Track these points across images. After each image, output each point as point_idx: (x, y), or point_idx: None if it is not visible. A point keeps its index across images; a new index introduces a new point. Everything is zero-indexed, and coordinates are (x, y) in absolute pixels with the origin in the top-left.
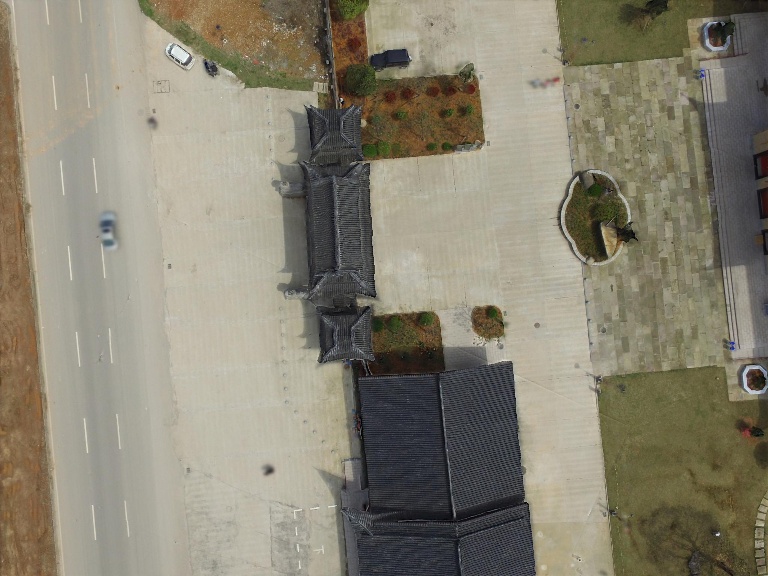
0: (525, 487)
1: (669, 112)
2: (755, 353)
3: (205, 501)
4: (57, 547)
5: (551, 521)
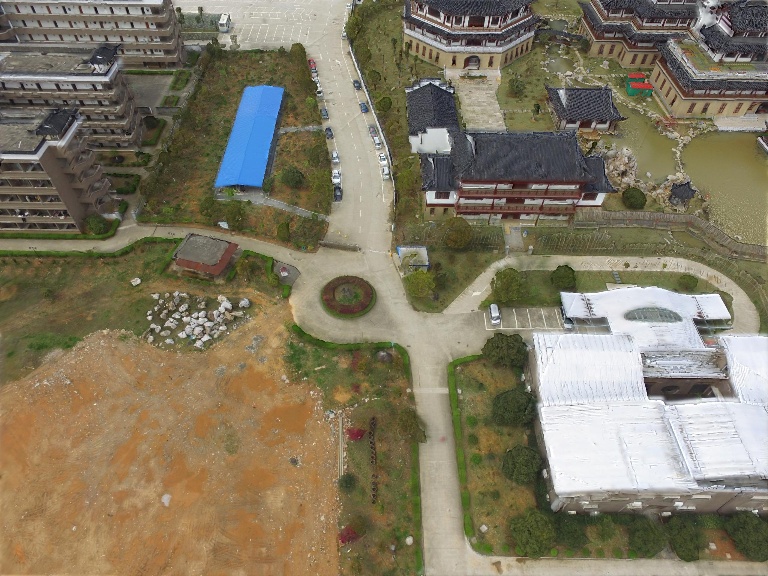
0: None
1: None
2: None
3: None
4: None
5: None
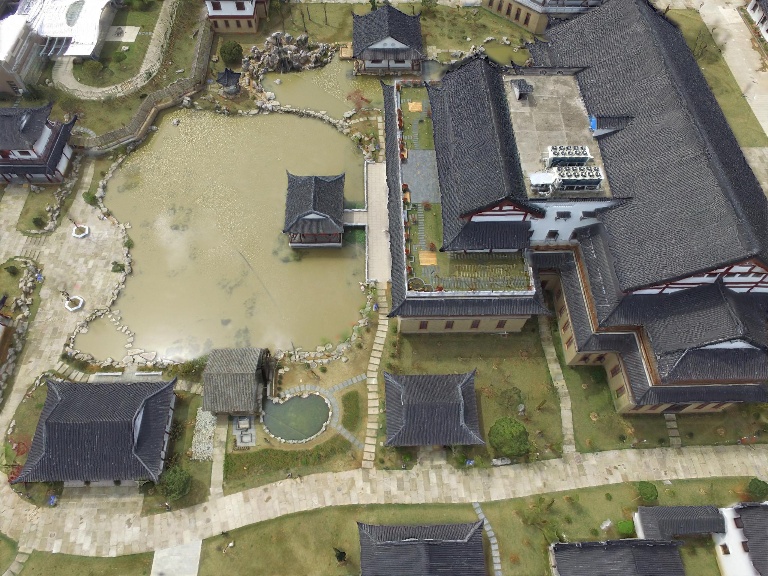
0: None
1: None
2: None
3: None
4: None
5: None
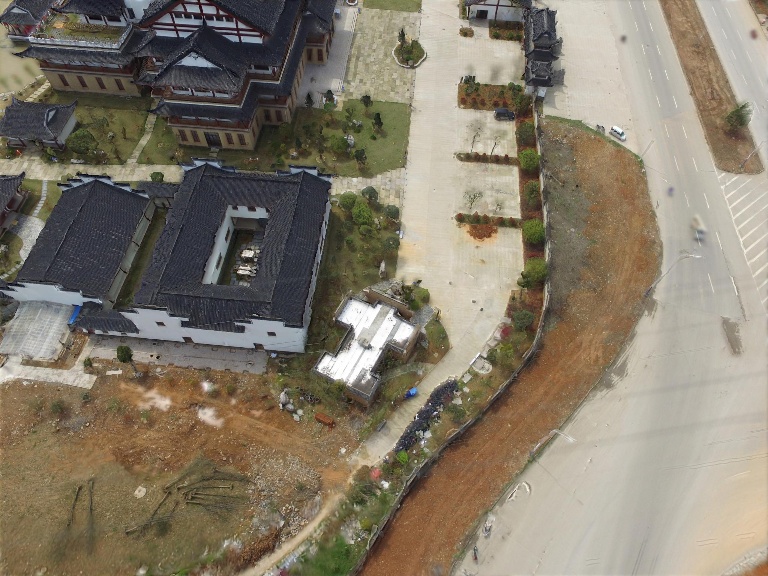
0: None
1: (362, 82)
2: (349, 8)
3: (596, 5)
4: (659, 1)
5: None
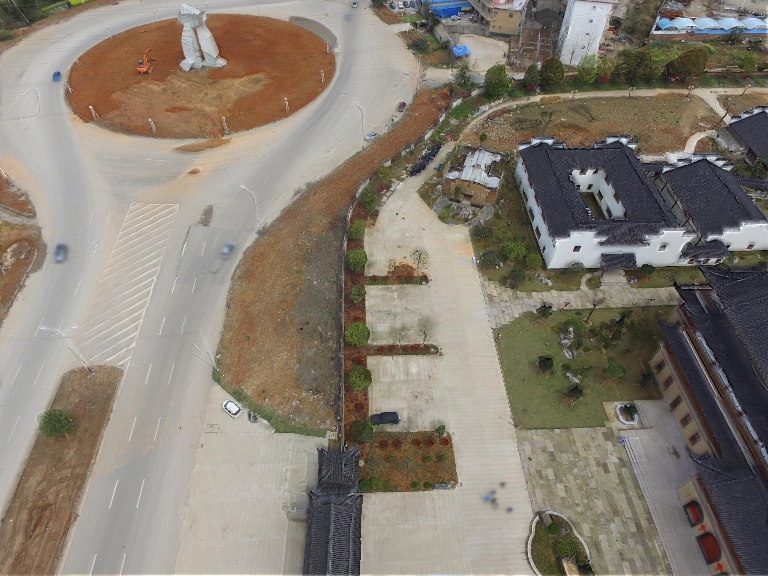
0: None
1: (604, 467)
2: None
3: None
4: None
5: None
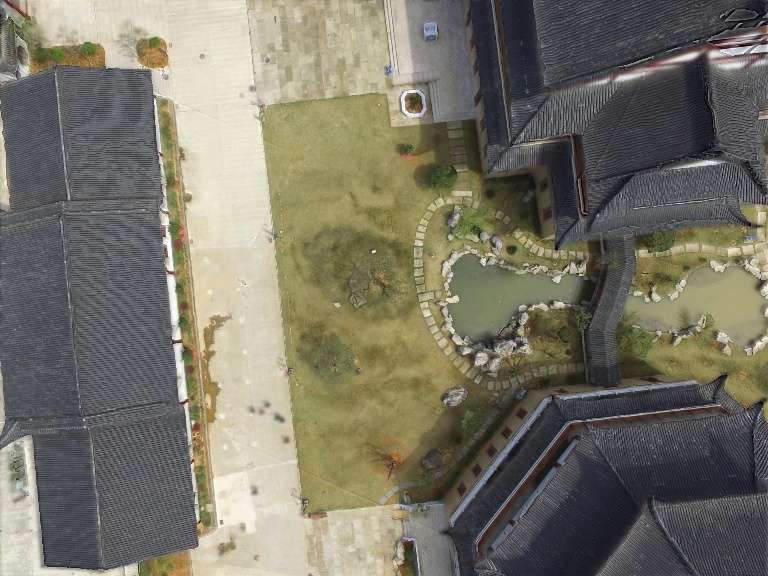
0: (191, 213)
1: None
2: (415, 79)
3: None
4: None
5: (217, 246)
